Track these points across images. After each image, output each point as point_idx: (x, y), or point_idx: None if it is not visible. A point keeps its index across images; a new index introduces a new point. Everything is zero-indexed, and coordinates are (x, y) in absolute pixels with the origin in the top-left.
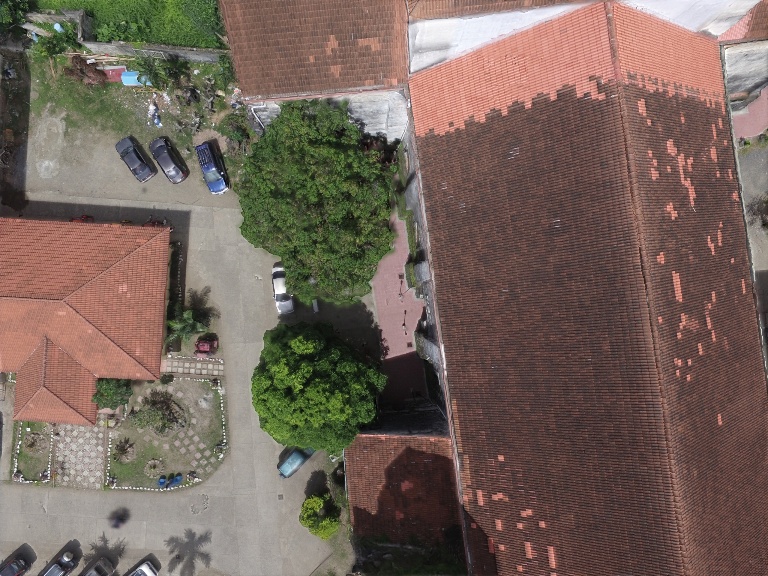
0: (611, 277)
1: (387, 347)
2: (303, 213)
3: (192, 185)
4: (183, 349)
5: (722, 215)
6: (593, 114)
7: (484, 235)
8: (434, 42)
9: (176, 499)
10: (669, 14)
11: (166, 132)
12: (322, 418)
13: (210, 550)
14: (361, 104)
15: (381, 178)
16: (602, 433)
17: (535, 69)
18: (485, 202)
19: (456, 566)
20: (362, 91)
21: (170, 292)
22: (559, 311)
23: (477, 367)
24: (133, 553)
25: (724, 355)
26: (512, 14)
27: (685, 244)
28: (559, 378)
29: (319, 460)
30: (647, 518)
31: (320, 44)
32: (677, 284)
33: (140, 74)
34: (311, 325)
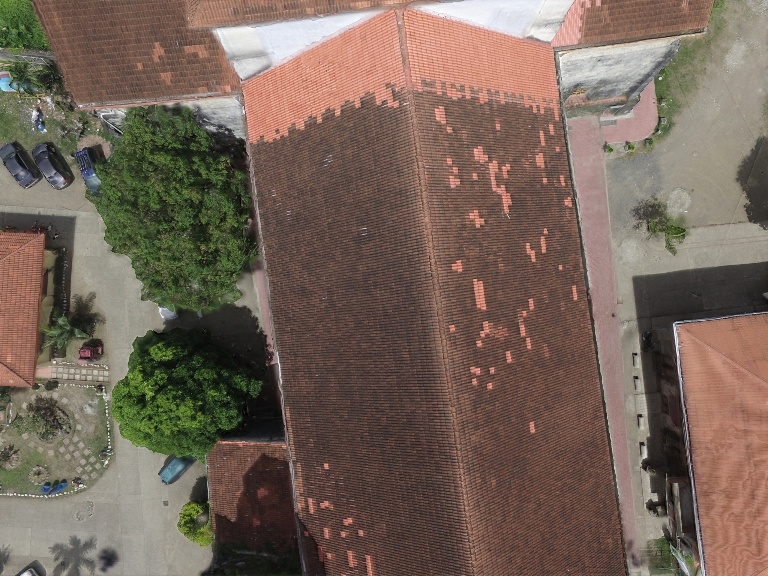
0: (408, 285)
1: (272, 353)
2: (140, 220)
3: (77, 191)
4: (68, 355)
5: (547, 222)
6: (390, 122)
7: (306, 242)
8: (246, 50)
9: (61, 506)
10: (480, 21)
11: (51, 138)
12: (174, 425)
13: (95, 557)
14: (213, 110)
15: (227, 185)
16: (405, 442)
17: (342, 77)
18: (307, 209)
19: (299, 574)
20: (197, 98)
21: (54, 298)
22: (368, 319)
23: (304, 375)
24: (18, 560)
25: (542, 362)
26: (307, 22)
27: (493, 252)
28: (369, 386)
29: (204, 466)
30: (443, 527)
31: (146, 51)
32: (480, 292)
33: (12, 80)
34: (185, 331)
